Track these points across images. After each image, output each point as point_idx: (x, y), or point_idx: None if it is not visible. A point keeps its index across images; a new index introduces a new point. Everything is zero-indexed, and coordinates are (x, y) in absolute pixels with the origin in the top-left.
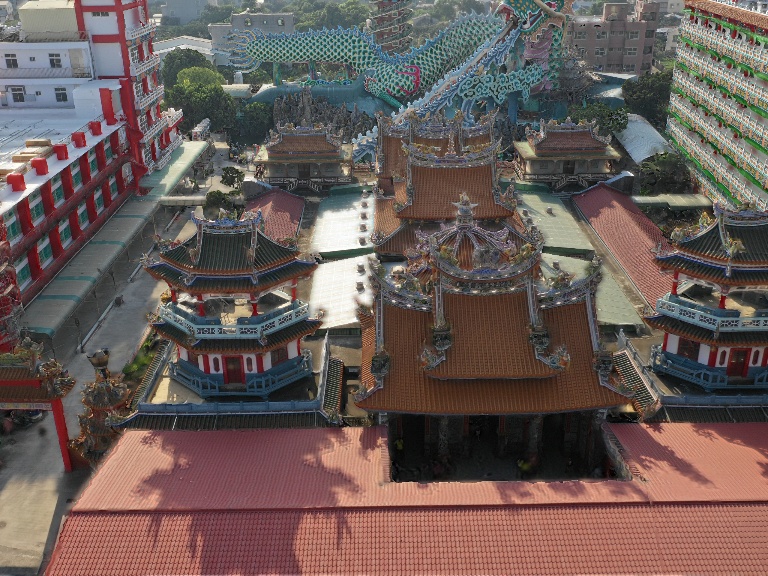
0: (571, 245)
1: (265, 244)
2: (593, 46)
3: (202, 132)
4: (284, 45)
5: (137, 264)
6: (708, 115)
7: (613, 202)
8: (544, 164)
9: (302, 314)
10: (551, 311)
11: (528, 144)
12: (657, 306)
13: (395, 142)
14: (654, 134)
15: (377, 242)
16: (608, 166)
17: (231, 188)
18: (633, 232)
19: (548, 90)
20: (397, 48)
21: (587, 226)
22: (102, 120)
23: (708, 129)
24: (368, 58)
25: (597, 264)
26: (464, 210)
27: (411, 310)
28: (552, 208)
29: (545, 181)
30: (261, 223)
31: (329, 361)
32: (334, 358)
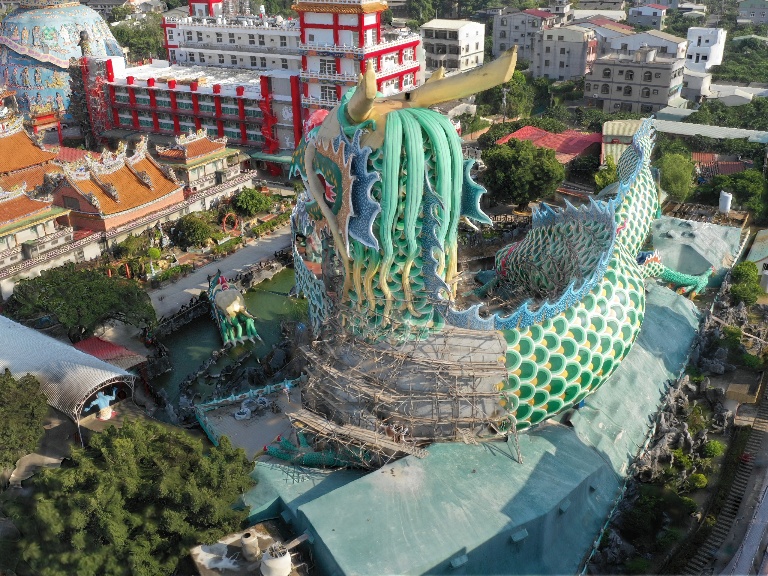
0: None
1: None
2: None
3: None
4: None
5: None
6: None
7: None
8: None
9: None
10: None
11: None
12: None
13: None
14: None
15: None
16: None
17: None
18: None
19: None
20: None
21: None
22: None
23: None
24: None
25: None
26: None
27: None
28: None
29: None
30: None
31: None
32: None
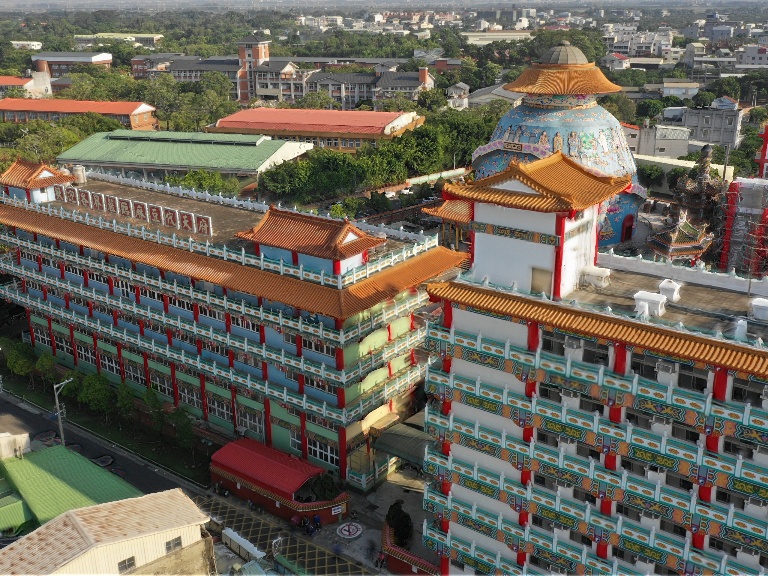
0: None
1: None
2: None
3: None
4: None
5: None
6: None
7: None
8: None
9: None
10: None
11: None
12: None
13: None
14: None
15: None
16: None
17: None
18: None
19: None
20: None
21: None
22: None
23: None
24: None
25: None
26: None
27: None
28: None
29: None
30: None
31: None
32: None
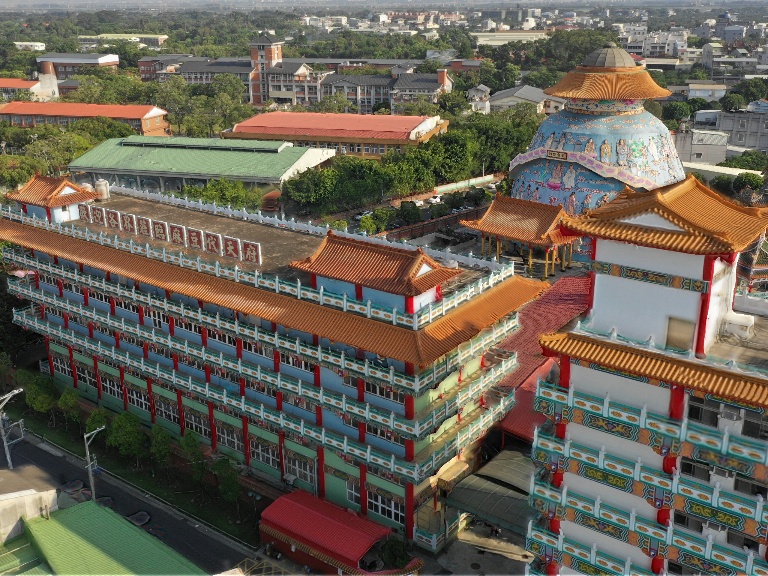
0: None
1: None
2: None
3: None
4: None
5: None
6: None
7: None
8: None
9: None
10: None
11: None
12: None
13: None
14: None
15: None
16: None
17: None
18: None
19: None
20: None
21: None
22: None
23: None
24: None
25: None
26: None
27: None
28: None
29: None
30: None
31: None
32: None
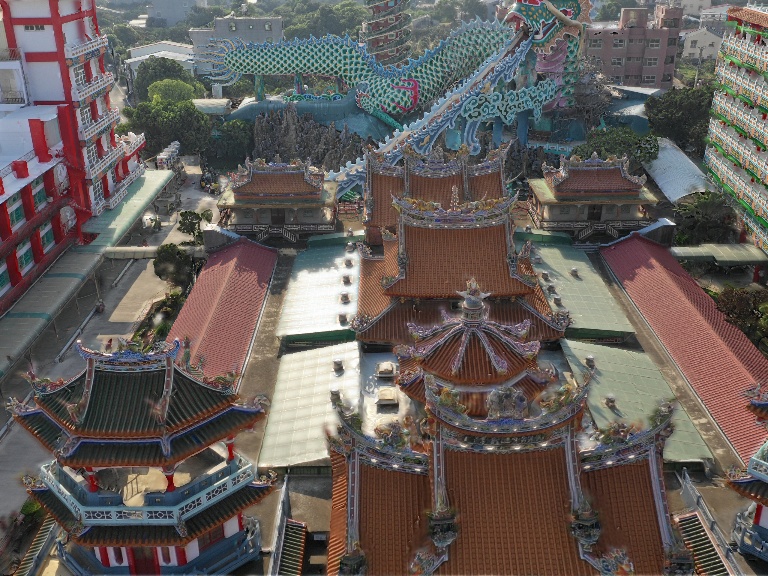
0: (605, 325)
1: (185, 387)
2: (609, 55)
3: (168, 158)
4: (266, 56)
5: (71, 335)
6: (761, 150)
7: (651, 260)
8: (565, 208)
9: (243, 479)
10: (598, 474)
11: (545, 183)
12: (749, 467)
13: (387, 181)
14: (688, 164)
15: (360, 328)
16: (641, 210)
17: None
18: (681, 306)
19: (562, 108)
20: (394, 57)
21: (621, 292)
22: (32, 157)
23: (763, 168)
24: (360, 70)
25: (666, 411)
26: (472, 301)
27: (399, 472)
28: (577, 268)
29: (566, 229)
30: (185, 347)
31: (286, 528)
32: (293, 522)
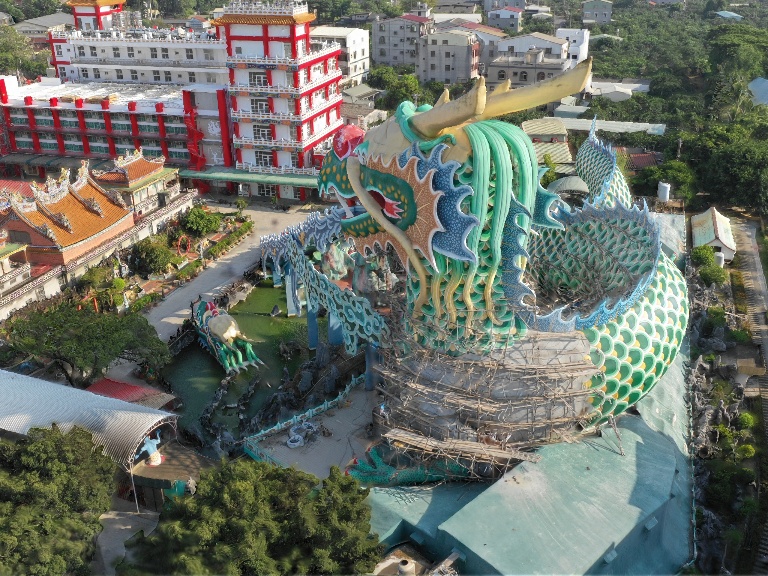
0: None
1: None
2: None
3: None
4: None
5: None
6: None
7: None
8: None
9: None
10: None
11: None
12: None
13: None
14: (3, 398)
15: None
16: None
17: (271, 218)
18: None
19: None
20: None
21: None
22: None
23: None
24: None
25: None
26: None
27: None
28: None
29: None
30: None
31: None
32: None
